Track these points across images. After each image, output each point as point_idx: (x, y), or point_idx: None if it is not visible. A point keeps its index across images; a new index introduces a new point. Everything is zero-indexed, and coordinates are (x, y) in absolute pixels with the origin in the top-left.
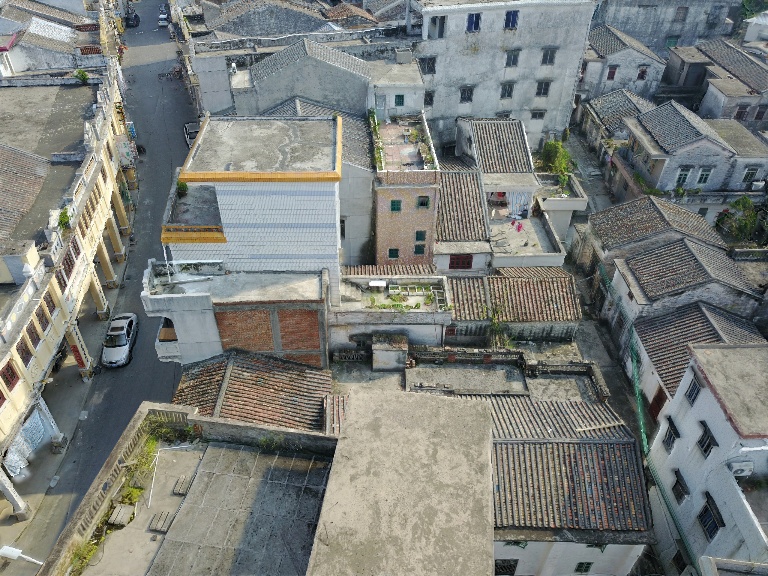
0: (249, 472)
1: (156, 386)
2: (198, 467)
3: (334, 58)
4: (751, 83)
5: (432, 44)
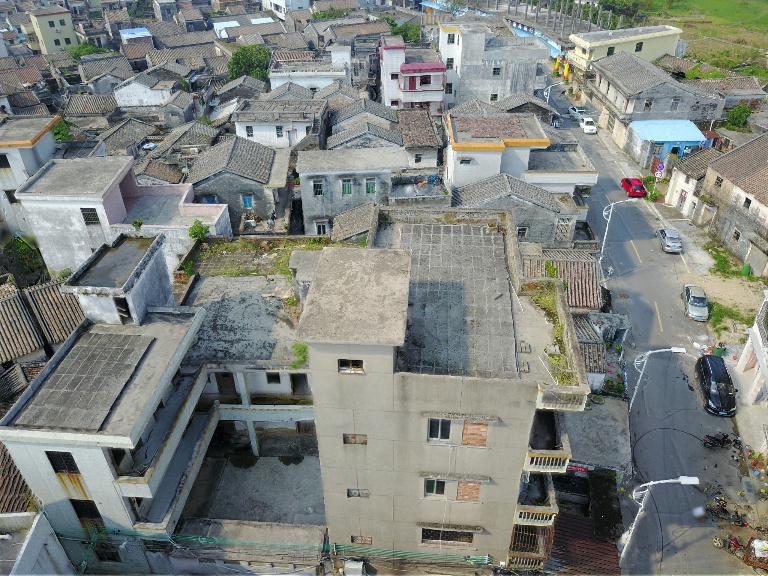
0: (479, 373)
1: None
2: None
3: None
4: None
5: None
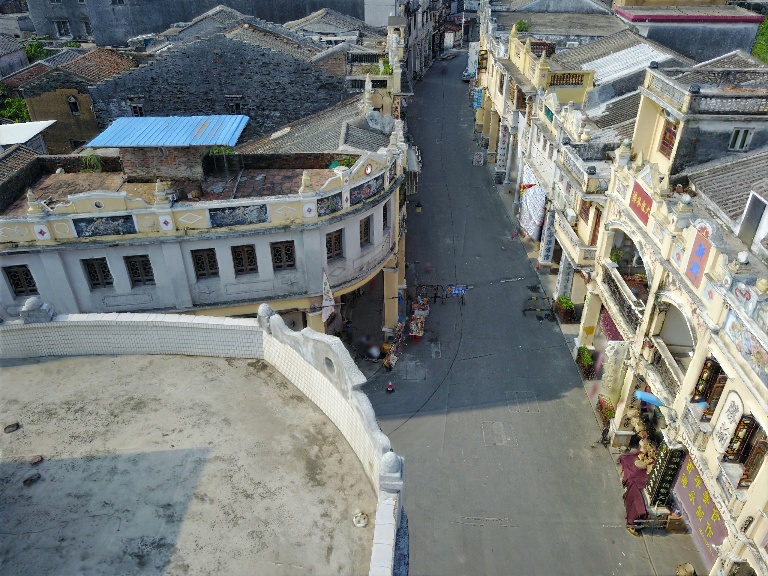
0: None
1: (452, 70)
2: None
3: None
4: None
5: None
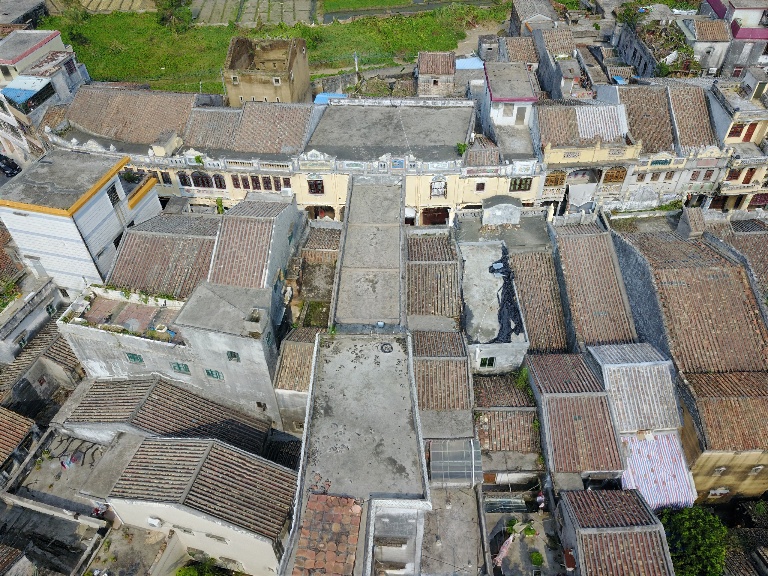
0: None
1: None
2: None
3: (240, 245)
4: None
5: None
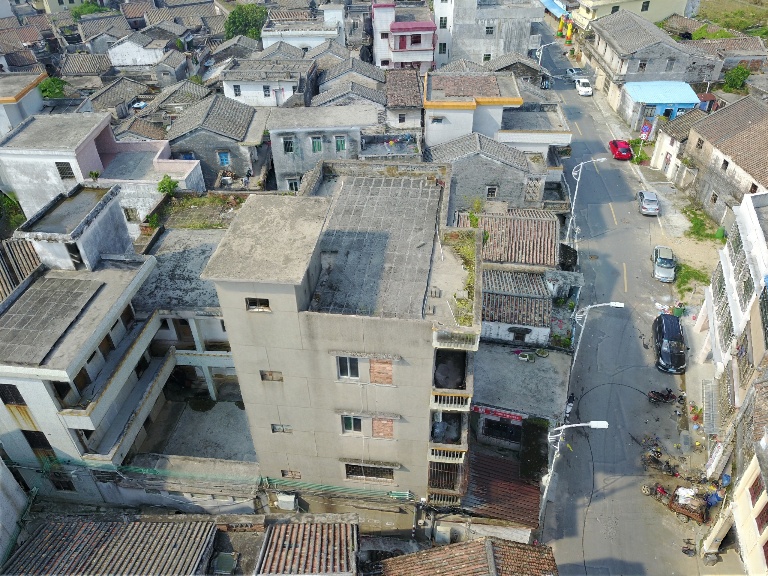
0: (384, 314)
1: None
2: (422, 316)
3: None
4: None
5: None
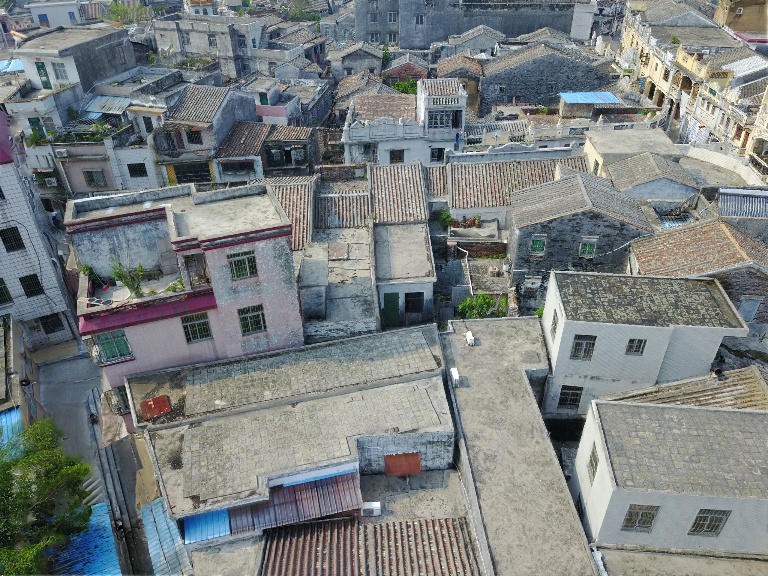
0: None
1: None
2: None
3: None
4: (276, 22)
5: (457, 1)
